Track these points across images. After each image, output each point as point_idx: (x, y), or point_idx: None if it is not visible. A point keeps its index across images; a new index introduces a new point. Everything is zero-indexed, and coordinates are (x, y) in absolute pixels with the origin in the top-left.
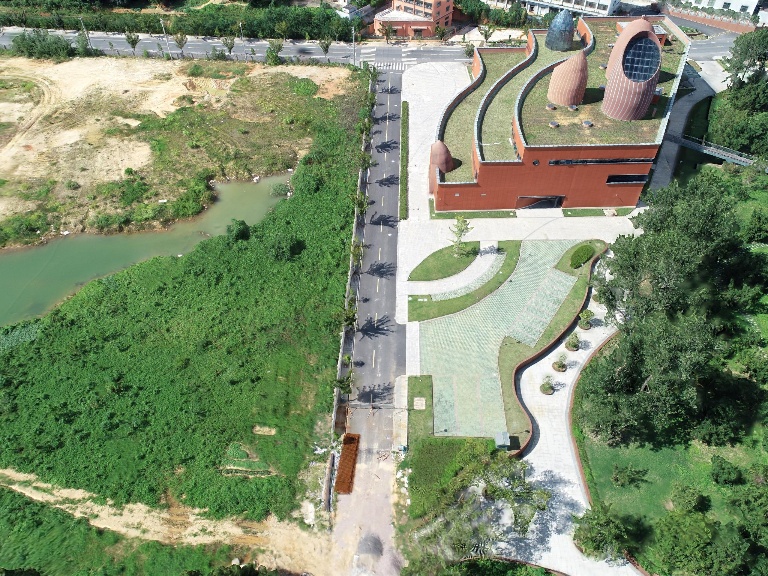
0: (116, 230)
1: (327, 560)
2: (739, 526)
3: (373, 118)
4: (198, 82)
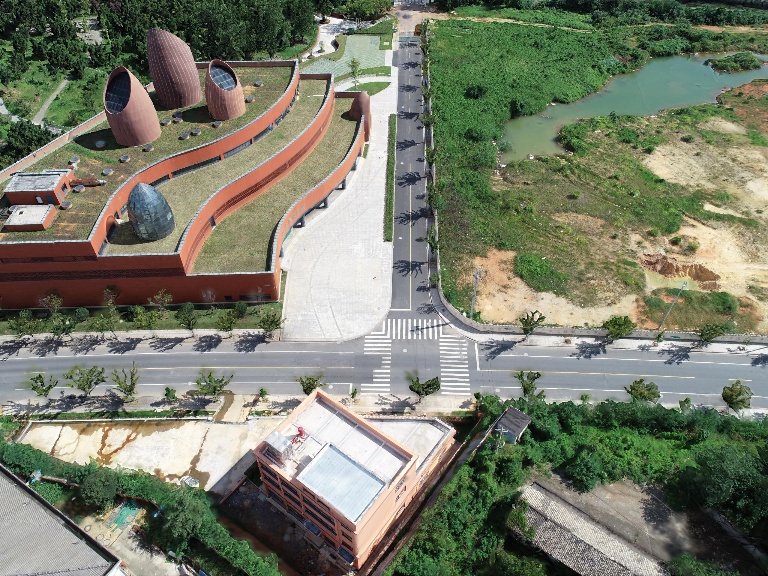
0: None
1: None
2: None
3: (428, 216)
4: None
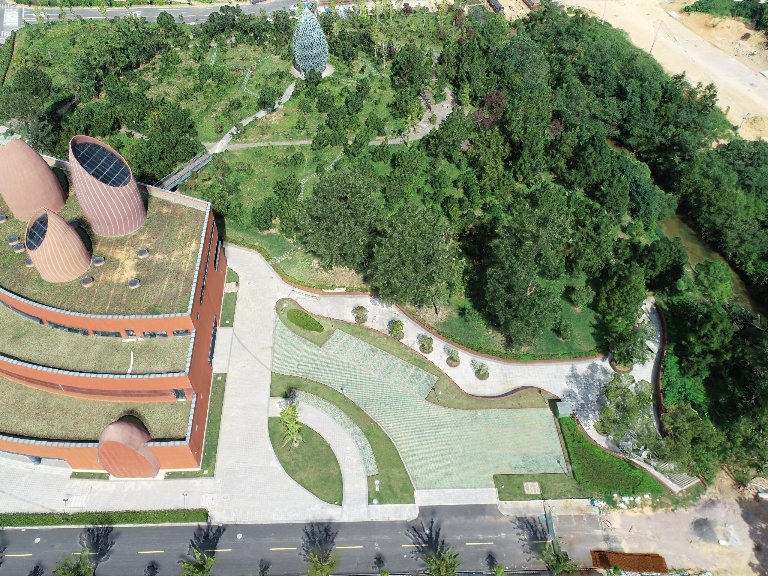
0: None
1: (736, 572)
2: (599, 271)
3: None
4: None
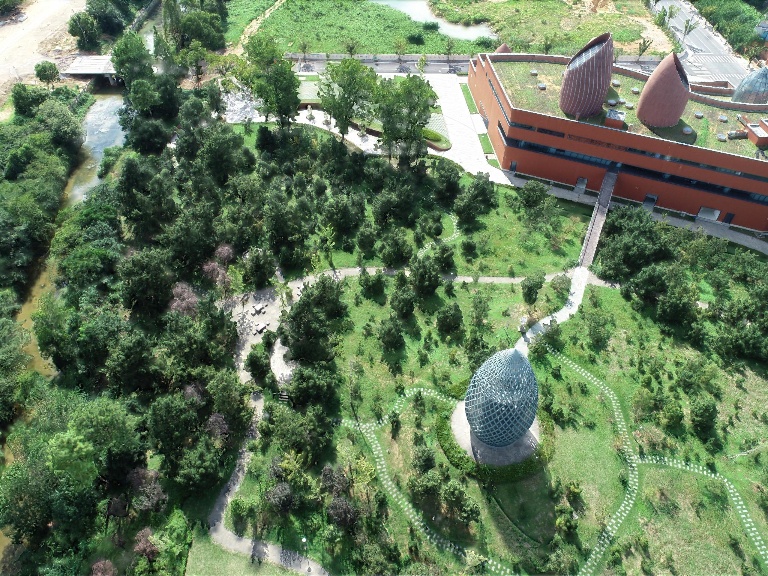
0: (430, 5)
1: None
2: None
3: None
4: (609, 4)
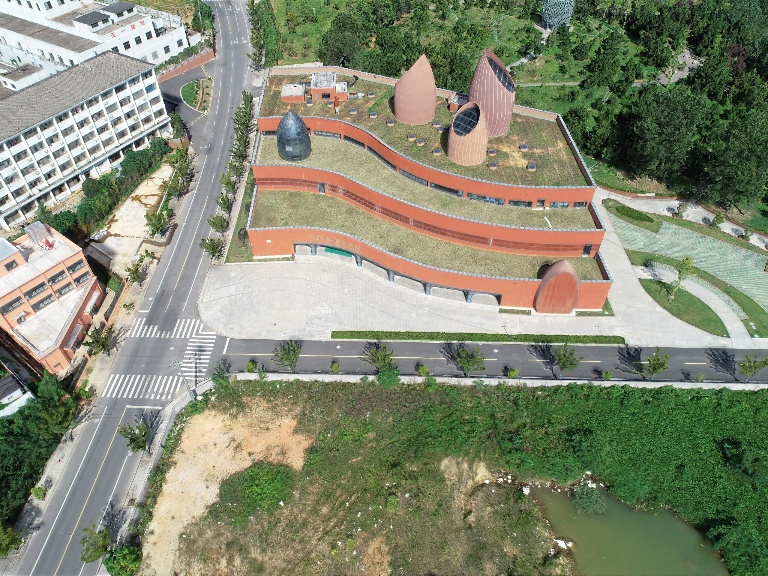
0: None
1: None
2: None
3: None
4: None
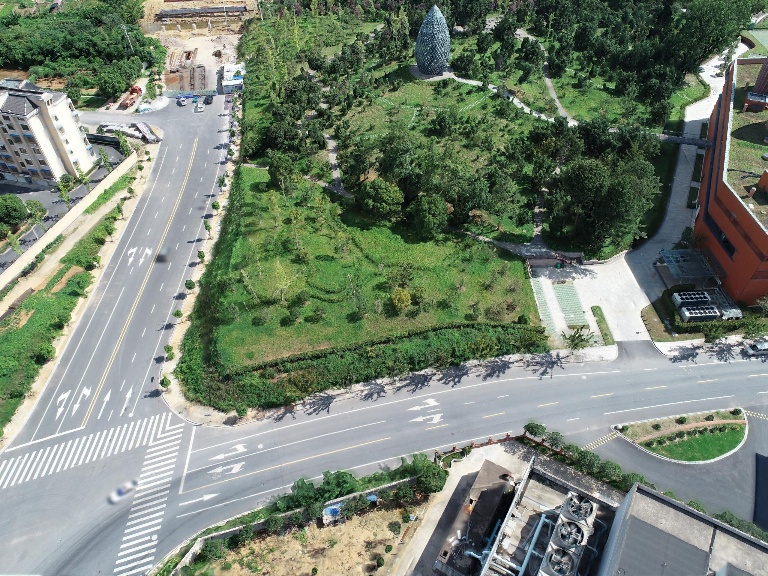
0: None
1: None
2: None
3: None
4: None
